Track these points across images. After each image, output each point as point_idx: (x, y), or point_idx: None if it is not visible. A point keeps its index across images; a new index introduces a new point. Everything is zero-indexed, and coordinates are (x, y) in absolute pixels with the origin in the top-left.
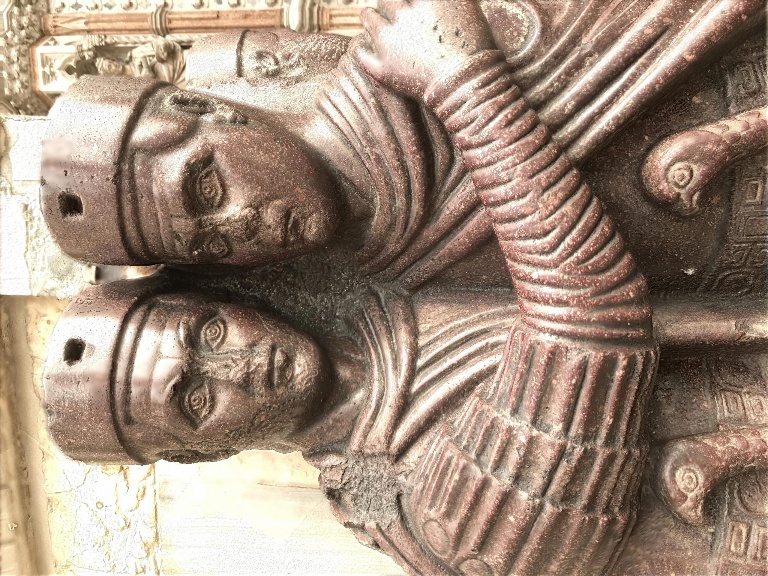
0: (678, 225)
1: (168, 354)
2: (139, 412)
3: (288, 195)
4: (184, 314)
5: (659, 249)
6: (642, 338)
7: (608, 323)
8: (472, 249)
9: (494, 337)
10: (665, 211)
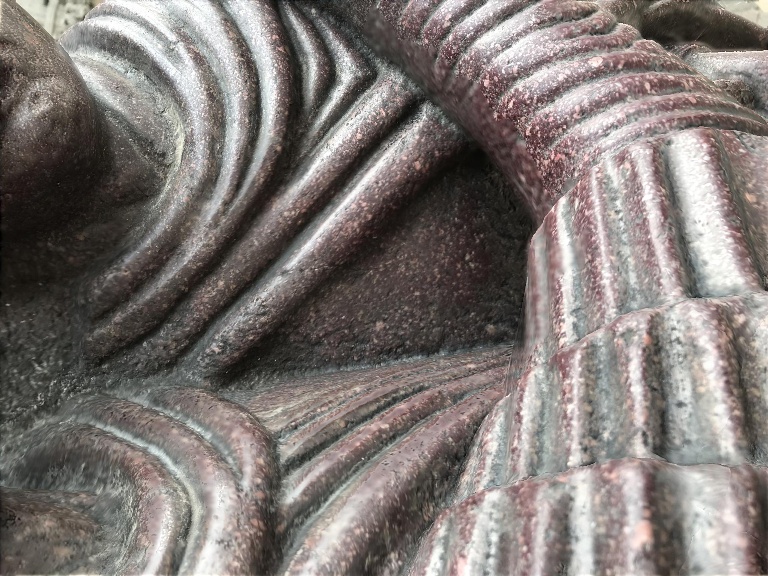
0: None
1: None
2: None
3: None
4: None
5: None
6: None
7: None
8: (369, 234)
9: (448, 384)
10: None
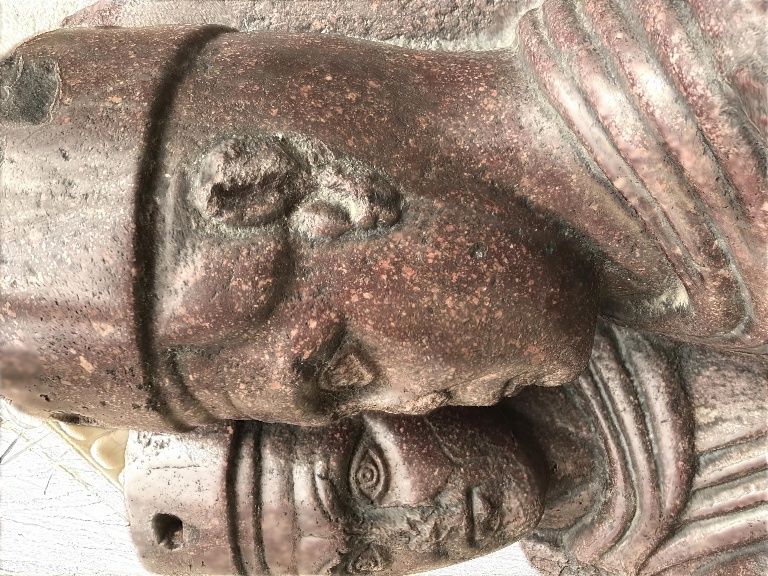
0: None
1: (311, 531)
2: None
3: (510, 365)
4: (315, 453)
5: None
6: None
7: None
8: None
9: None
10: None
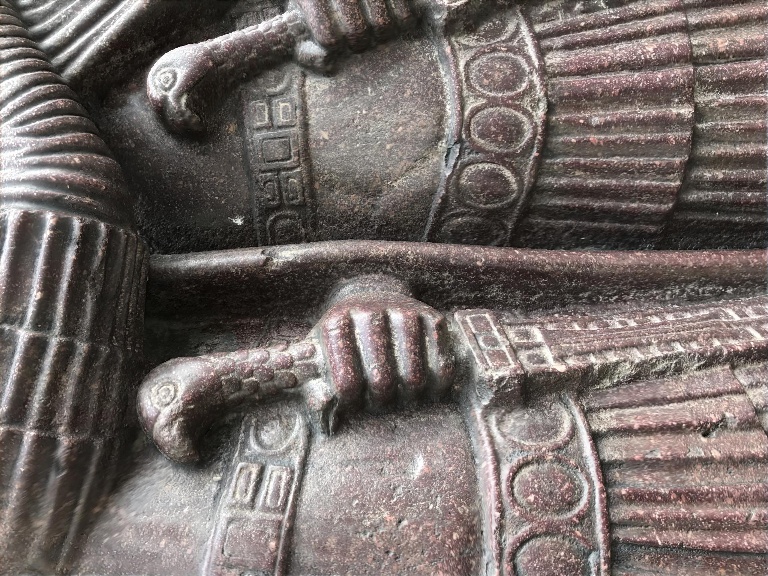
0: (206, 159)
1: None
2: None
3: None
4: None
5: (197, 191)
6: (91, 209)
7: (41, 183)
8: None
9: None
10: (190, 144)
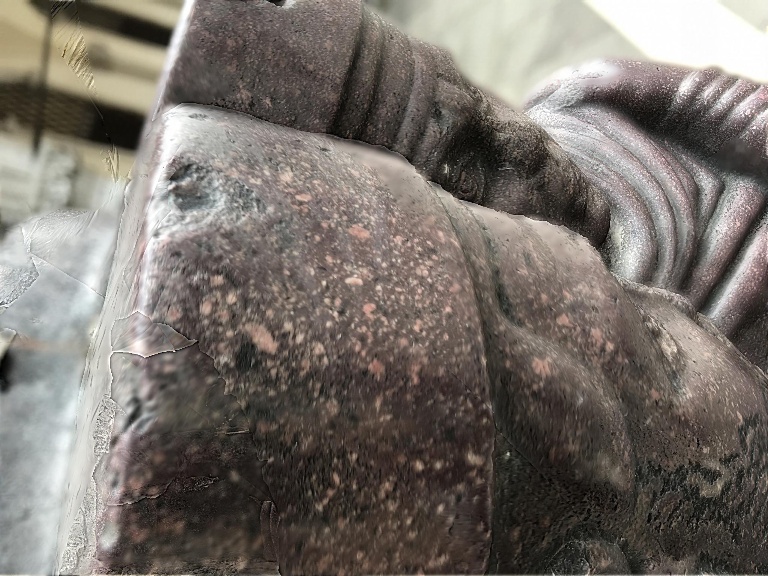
0: None
1: None
2: (526, 282)
3: None
4: None
5: None
6: None
7: None
8: (759, 291)
9: None
10: None
